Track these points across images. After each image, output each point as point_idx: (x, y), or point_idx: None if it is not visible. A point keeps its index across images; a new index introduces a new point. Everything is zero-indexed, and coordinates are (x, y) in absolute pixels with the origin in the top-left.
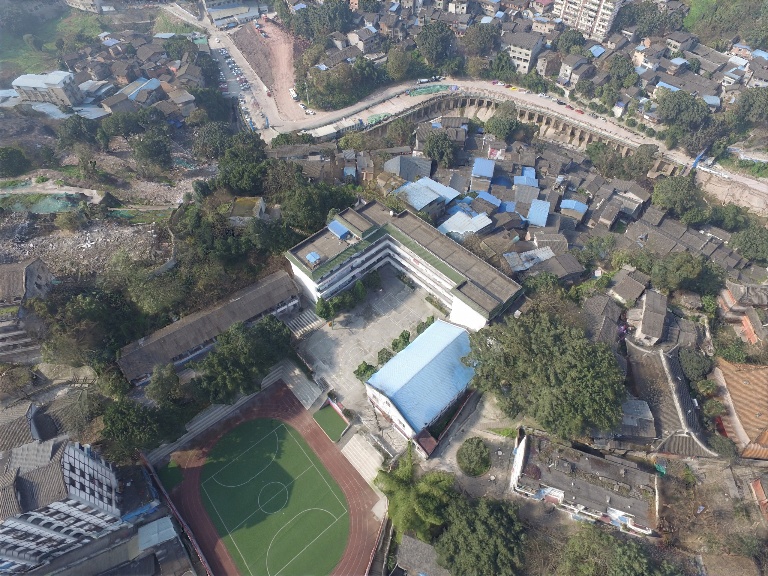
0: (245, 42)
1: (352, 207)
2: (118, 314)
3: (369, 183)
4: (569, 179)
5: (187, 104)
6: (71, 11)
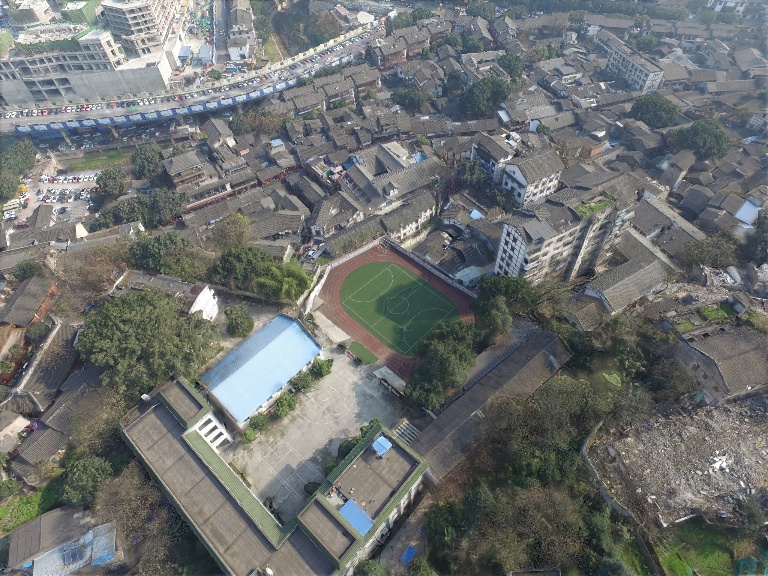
0: None
1: None
2: (602, 386)
3: None
4: None
5: None
6: None
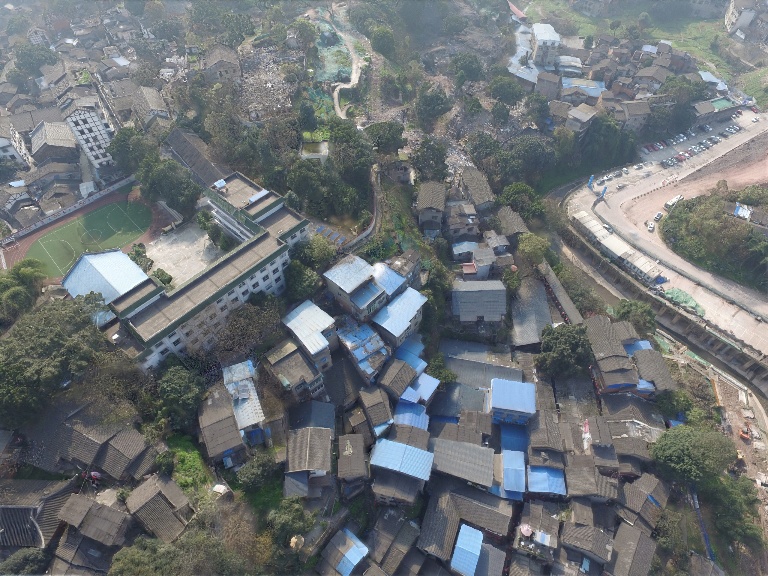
0: (767, 139)
1: (349, 230)
2: None
3: (461, 271)
4: (567, 570)
5: (576, 120)
6: (720, 20)
